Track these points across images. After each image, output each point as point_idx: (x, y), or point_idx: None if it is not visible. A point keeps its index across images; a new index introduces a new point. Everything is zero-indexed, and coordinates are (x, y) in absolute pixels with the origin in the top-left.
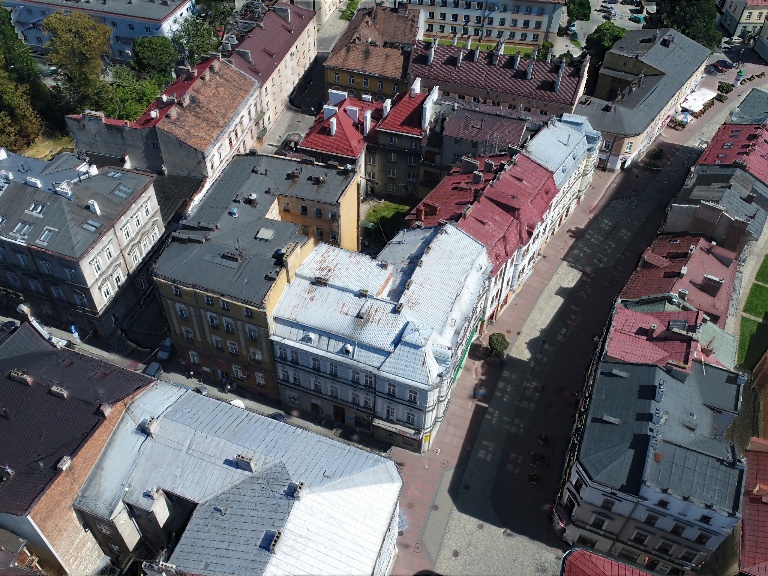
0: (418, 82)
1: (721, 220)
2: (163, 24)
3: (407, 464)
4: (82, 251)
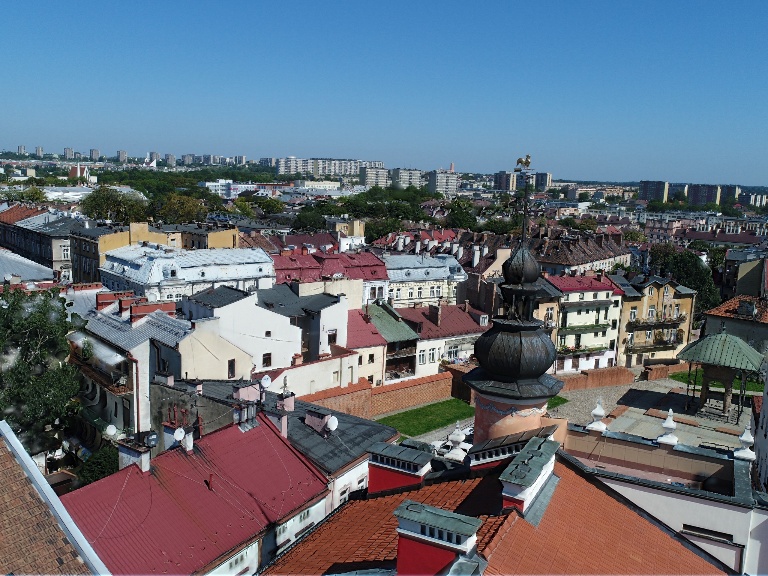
0: None
1: (482, 288)
2: None
3: None
4: (58, 234)
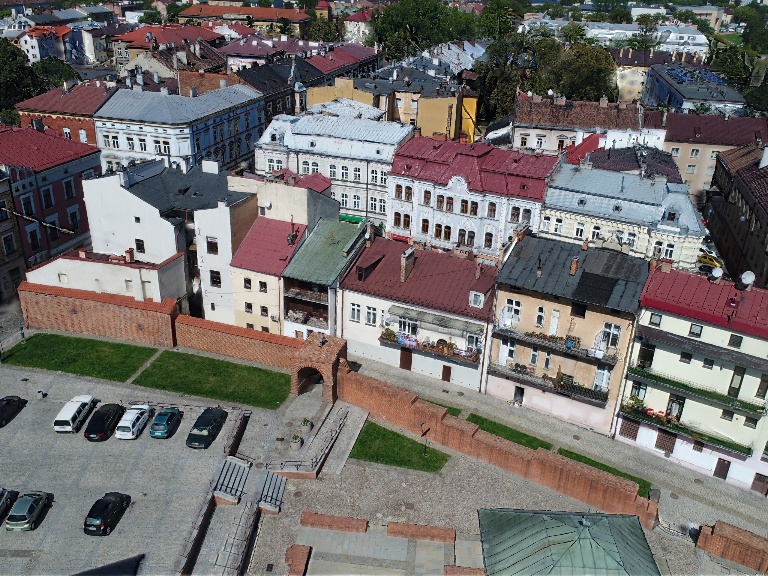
0: (657, 130)
1: None
2: (687, 102)
3: None
4: None
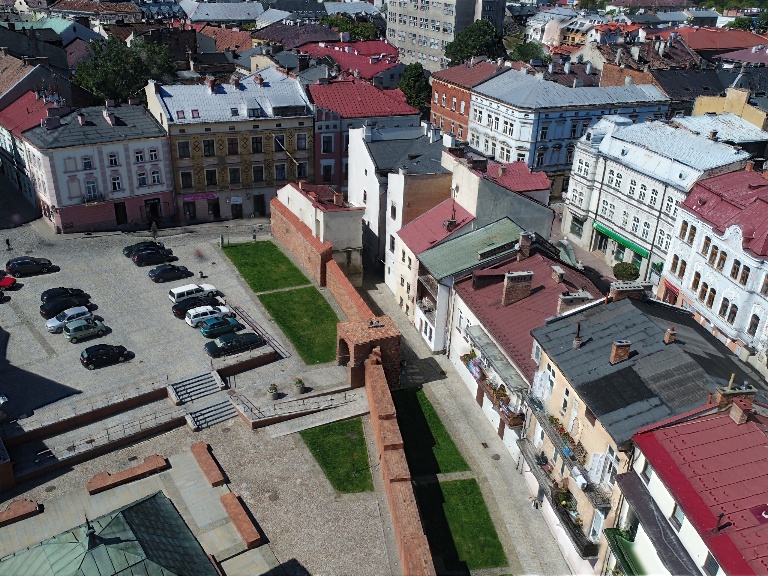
0: None
1: None
2: None
3: (560, 224)
4: None
